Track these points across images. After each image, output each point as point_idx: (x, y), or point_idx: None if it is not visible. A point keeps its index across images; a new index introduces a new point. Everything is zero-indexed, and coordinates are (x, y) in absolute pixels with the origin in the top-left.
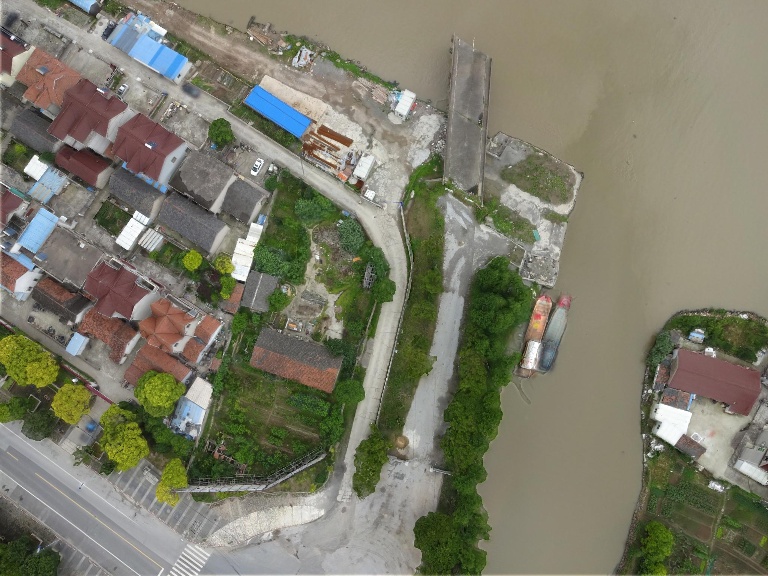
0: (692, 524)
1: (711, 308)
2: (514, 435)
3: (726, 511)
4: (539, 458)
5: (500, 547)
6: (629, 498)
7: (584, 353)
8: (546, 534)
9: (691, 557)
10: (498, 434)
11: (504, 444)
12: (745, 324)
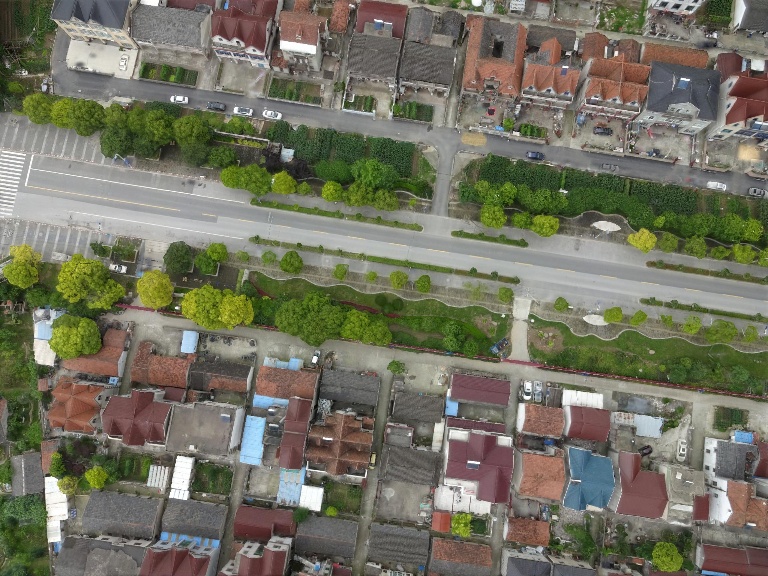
0: None
1: None
2: None
3: None
4: None
5: None
6: None
7: None
8: None
9: None
10: None
11: None
12: None
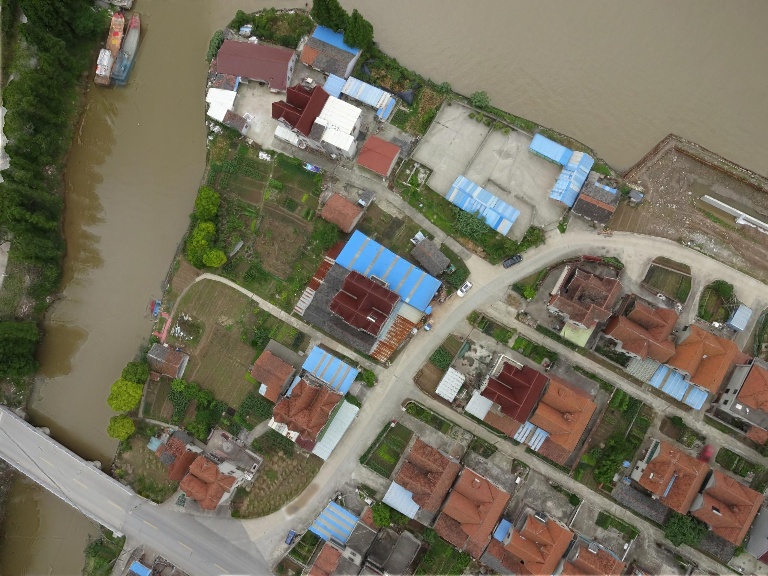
0: (245, 191)
1: (263, 8)
2: (133, 159)
3: (274, 176)
4: (146, 170)
5: (119, 253)
6: (196, 178)
7: (164, 64)
8: (146, 230)
9: (240, 215)
10: (123, 162)
11: (126, 168)
12: (291, 18)
